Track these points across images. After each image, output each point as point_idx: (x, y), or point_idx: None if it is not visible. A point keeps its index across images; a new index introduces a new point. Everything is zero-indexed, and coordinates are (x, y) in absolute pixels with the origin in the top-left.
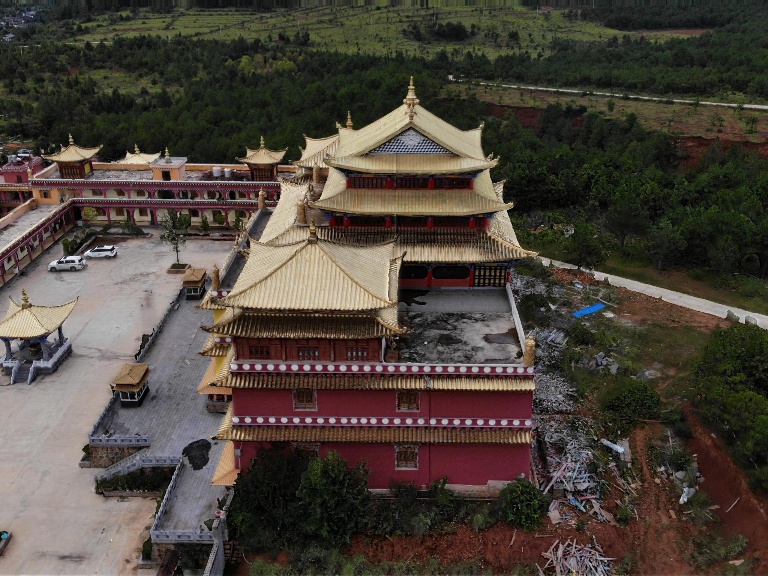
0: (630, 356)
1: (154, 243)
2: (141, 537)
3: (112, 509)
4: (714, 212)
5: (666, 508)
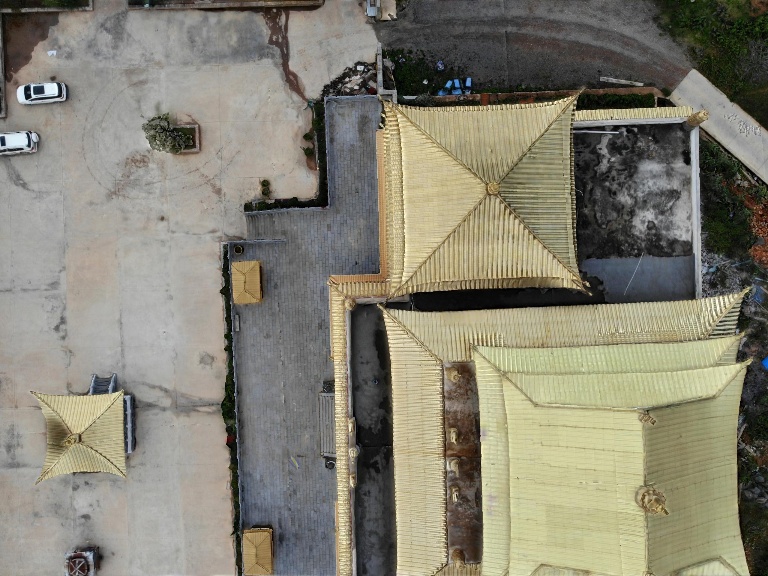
0: None
1: (109, 31)
2: None
3: None
4: None
5: None
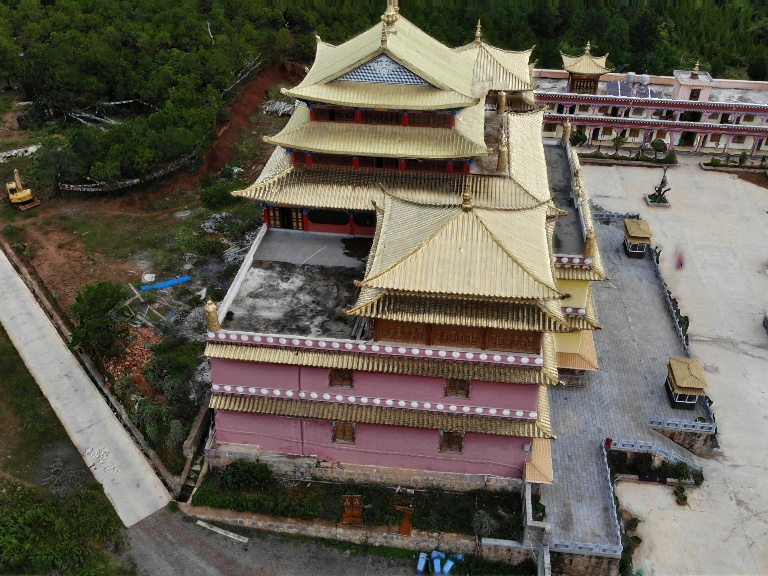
0: (185, 227)
1: None
2: None
3: None
4: None
5: (254, 170)
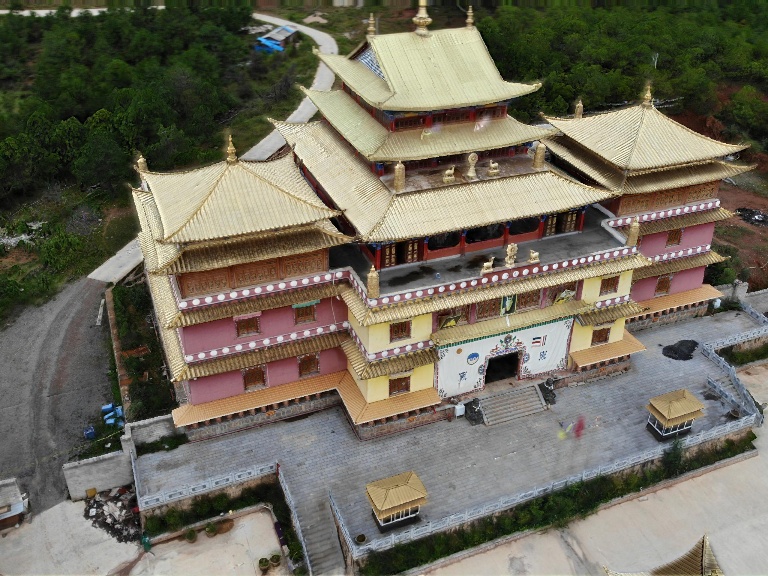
0: None
1: None
2: (759, 372)
3: (761, 402)
4: (141, 106)
5: None
